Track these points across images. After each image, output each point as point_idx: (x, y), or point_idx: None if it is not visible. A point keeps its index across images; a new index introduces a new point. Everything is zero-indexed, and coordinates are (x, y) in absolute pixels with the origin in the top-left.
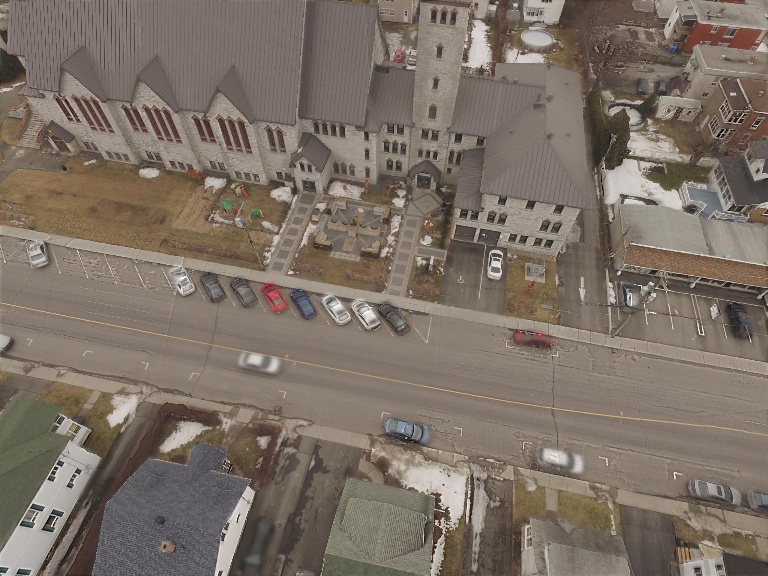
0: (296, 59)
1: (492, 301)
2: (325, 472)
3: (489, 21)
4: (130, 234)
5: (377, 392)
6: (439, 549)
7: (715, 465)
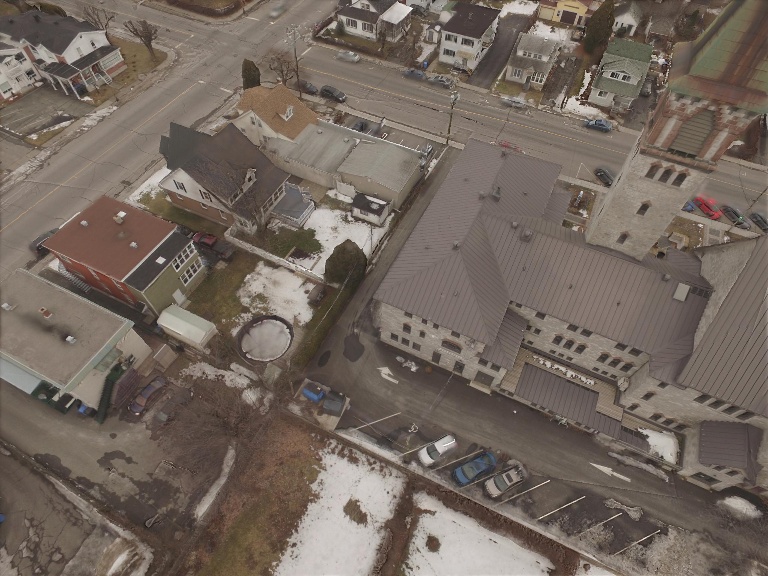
0: None
1: None
2: (643, 122)
3: None
4: None
5: (616, 145)
6: (582, 92)
7: (430, 91)
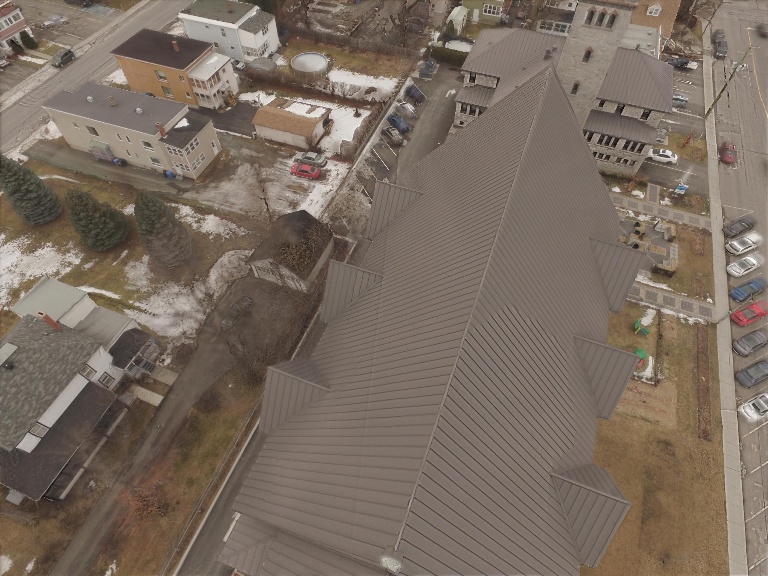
0: (593, 165)
1: (696, 168)
2: None
3: (251, 87)
4: (702, 487)
5: None
6: None
7: None
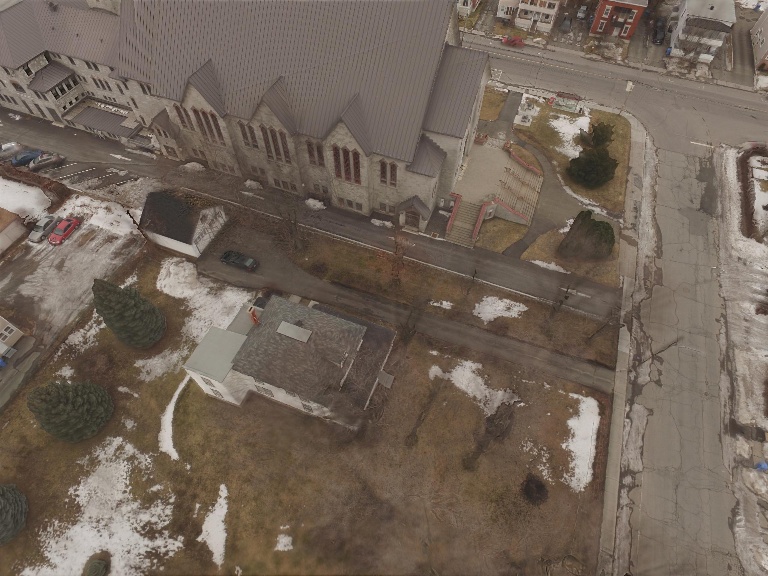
0: None
1: None
2: None
3: None
4: None
5: None
6: None
7: None
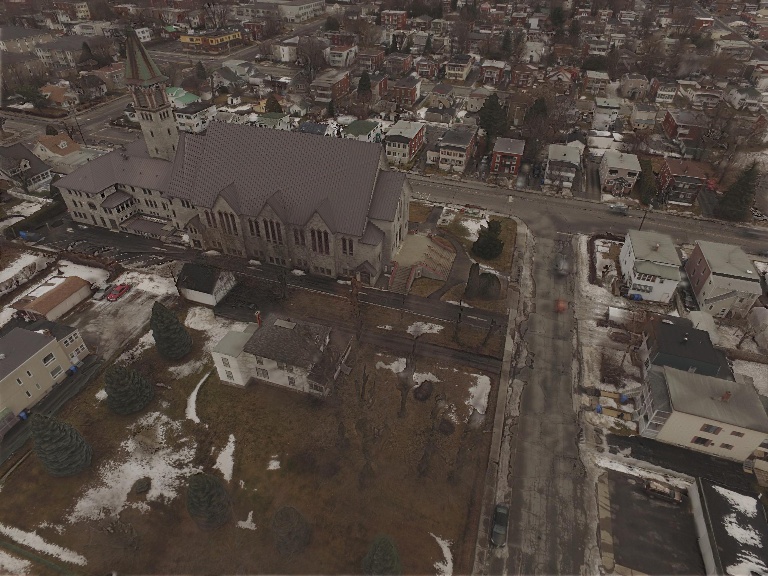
0: None
1: None
2: None
3: None
4: None
5: None
6: None
7: None
